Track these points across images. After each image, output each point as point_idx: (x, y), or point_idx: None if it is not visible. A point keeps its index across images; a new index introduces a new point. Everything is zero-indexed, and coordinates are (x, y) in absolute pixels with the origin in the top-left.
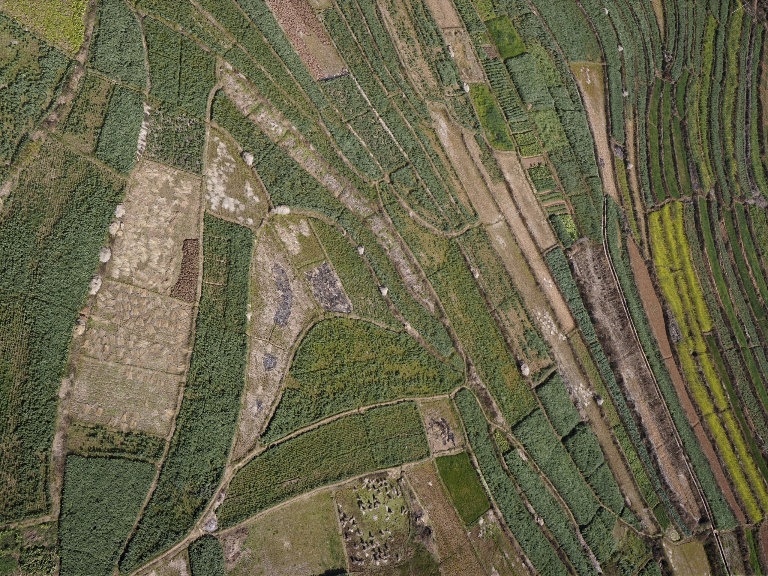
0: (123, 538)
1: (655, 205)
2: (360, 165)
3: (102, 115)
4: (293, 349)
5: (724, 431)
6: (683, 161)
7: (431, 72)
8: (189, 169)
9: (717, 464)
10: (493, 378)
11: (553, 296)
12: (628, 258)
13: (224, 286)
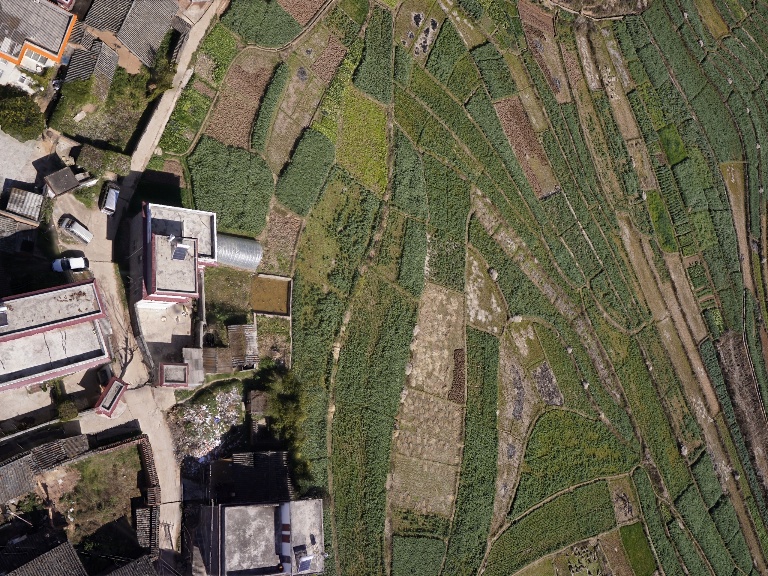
0: None
1: None
2: (570, 275)
3: (401, 247)
4: (526, 439)
5: None
6: None
7: (618, 183)
8: (456, 288)
9: None
10: (661, 458)
11: (704, 383)
12: (761, 346)
13: (481, 388)
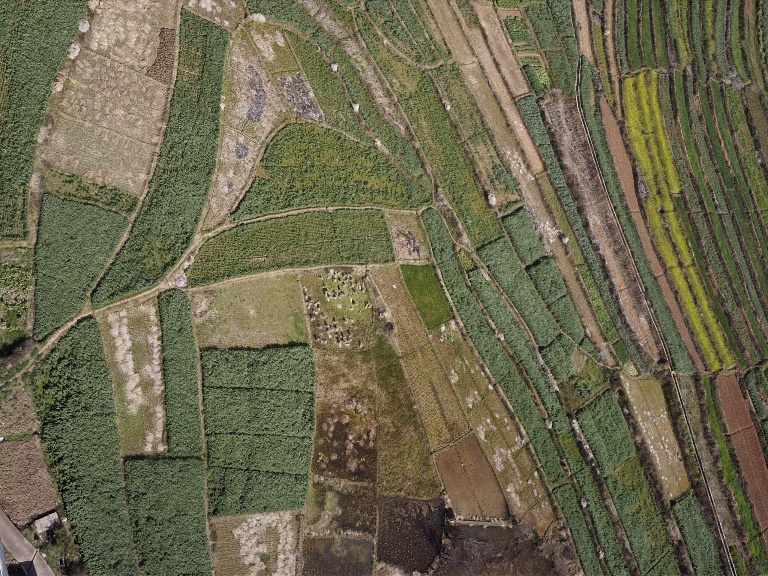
0: (96, 274)
1: (630, 72)
2: None
3: None
4: (264, 143)
5: (687, 284)
6: (661, 36)
7: None
8: None
9: (679, 314)
10: (460, 202)
11: (523, 139)
12: (600, 116)
13: (199, 76)
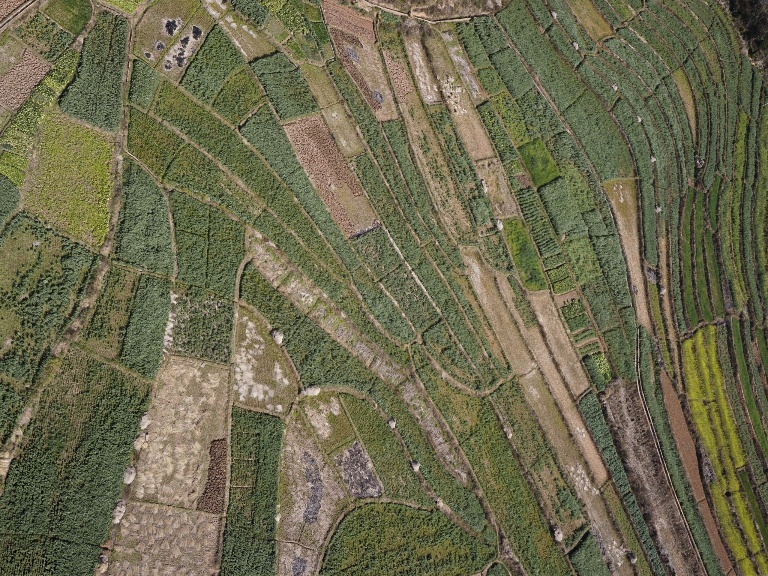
0: None
1: (688, 331)
2: (392, 329)
3: (127, 313)
4: (323, 548)
5: None
6: (716, 278)
7: (464, 212)
8: (217, 359)
9: None
10: (526, 549)
11: (586, 447)
12: (661, 394)
13: (252, 488)
